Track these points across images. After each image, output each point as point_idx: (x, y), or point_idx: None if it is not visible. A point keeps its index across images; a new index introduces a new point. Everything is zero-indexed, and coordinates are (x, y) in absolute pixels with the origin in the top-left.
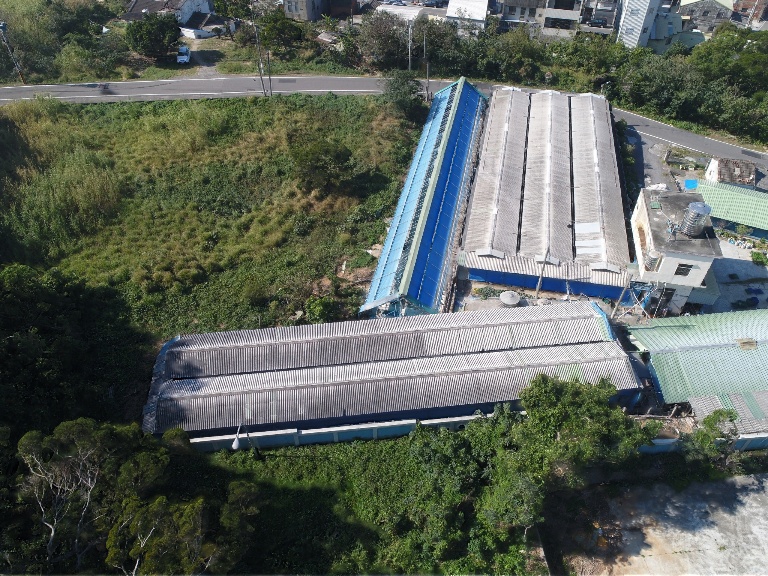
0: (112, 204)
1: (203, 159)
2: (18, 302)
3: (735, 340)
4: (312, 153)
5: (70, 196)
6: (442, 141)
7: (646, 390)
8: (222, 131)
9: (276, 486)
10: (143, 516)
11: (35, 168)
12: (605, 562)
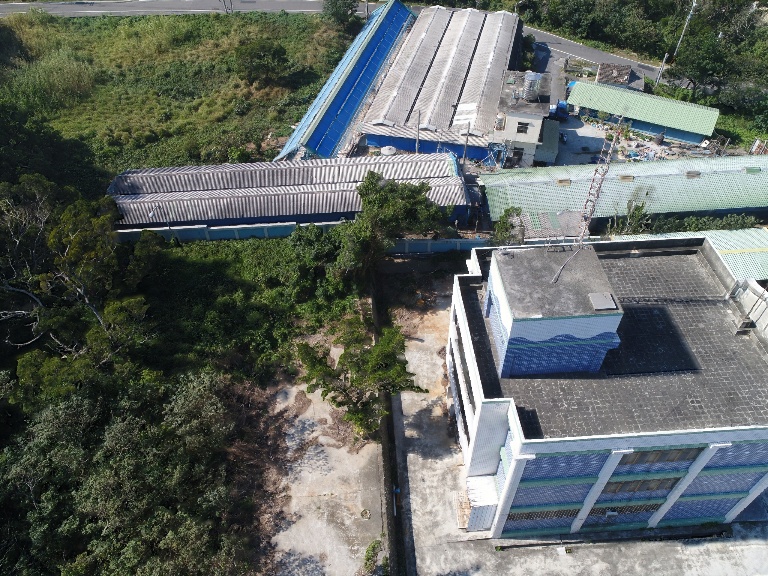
0: (87, 88)
1: (167, 59)
2: (4, 133)
3: (555, 179)
4: (251, 49)
5: (53, 78)
6: (363, 43)
7: (477, 210)
8: (186, 39)
9: (188, 261)
10: (73, 222)
11: (26, 58)
12: (419, 313)
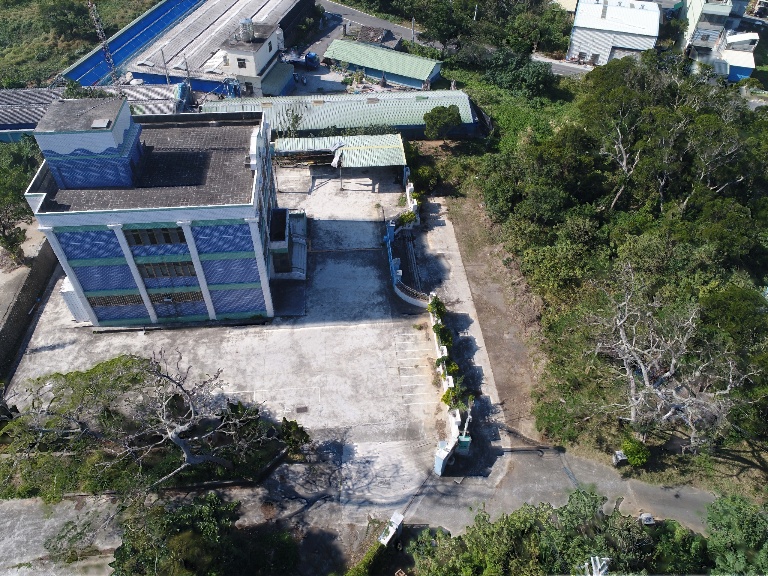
0: None
1: None
2: None
3: None
4: (54, 6)
5: None
6: (156, 5)
7: None
8: (17, 3)
9: None
10: None
11: None
12: None
